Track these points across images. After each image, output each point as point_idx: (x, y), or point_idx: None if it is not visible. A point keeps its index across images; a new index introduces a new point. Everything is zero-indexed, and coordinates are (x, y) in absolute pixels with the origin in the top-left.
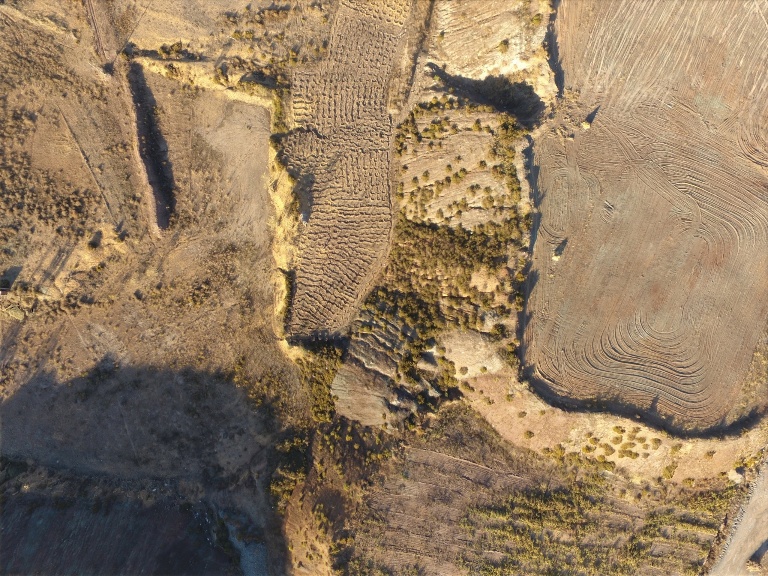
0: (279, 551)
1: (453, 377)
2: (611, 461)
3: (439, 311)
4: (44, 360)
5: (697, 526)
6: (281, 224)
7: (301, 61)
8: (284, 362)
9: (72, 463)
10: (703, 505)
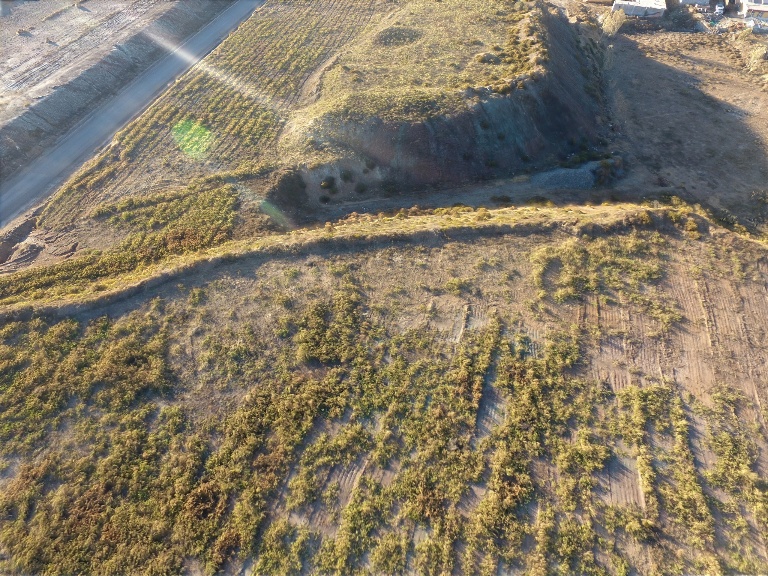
0: None
1: None
2: None
3: None
4: (705, 77)
5: None
6: None
7: None
8: None
9: None
10: None
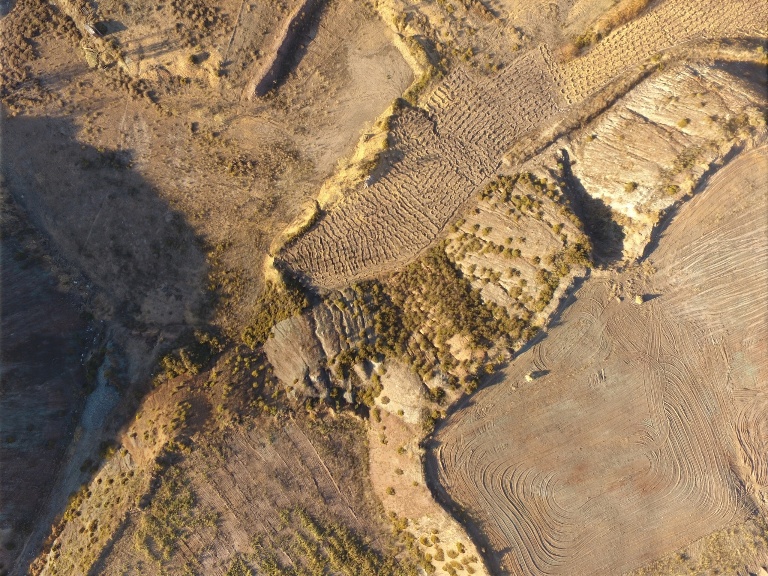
0: (127, 411)
1: (373, 398)
2: (434, 566)
3: (407, 340)
4: (81, 112)
5: None
6: (348, 170)
7: (471, 63)
8: (258, 274)
9: (32, 207)
10: None
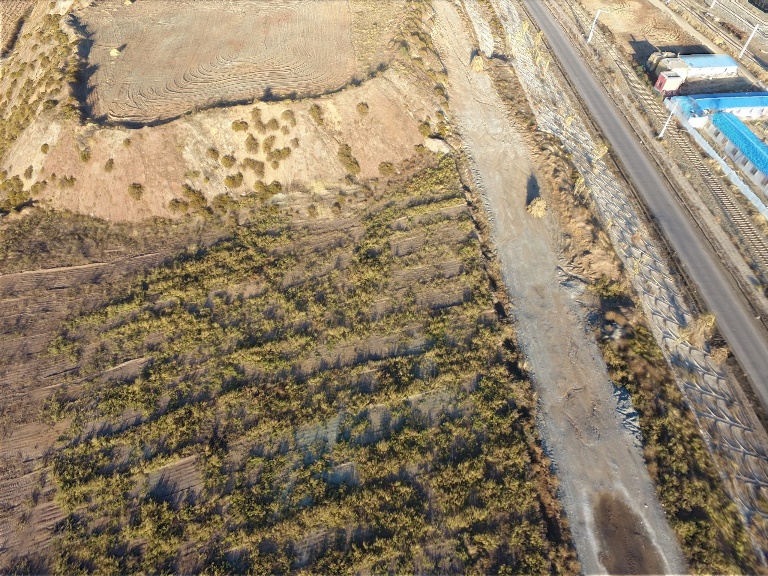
0: None
1: (21, 191)
2: (271, 182)
3: None
4: None
5: (433, 202)
6: None
7: None
8: None
9: None
10: (424, 182)
